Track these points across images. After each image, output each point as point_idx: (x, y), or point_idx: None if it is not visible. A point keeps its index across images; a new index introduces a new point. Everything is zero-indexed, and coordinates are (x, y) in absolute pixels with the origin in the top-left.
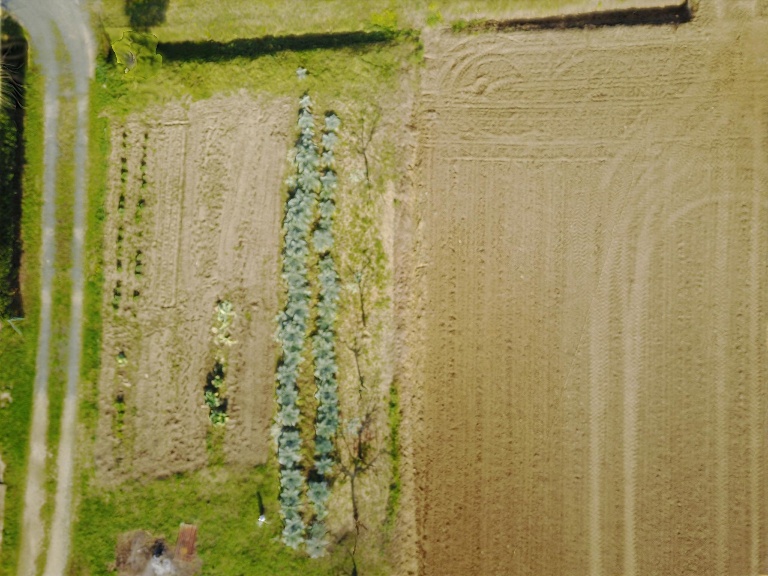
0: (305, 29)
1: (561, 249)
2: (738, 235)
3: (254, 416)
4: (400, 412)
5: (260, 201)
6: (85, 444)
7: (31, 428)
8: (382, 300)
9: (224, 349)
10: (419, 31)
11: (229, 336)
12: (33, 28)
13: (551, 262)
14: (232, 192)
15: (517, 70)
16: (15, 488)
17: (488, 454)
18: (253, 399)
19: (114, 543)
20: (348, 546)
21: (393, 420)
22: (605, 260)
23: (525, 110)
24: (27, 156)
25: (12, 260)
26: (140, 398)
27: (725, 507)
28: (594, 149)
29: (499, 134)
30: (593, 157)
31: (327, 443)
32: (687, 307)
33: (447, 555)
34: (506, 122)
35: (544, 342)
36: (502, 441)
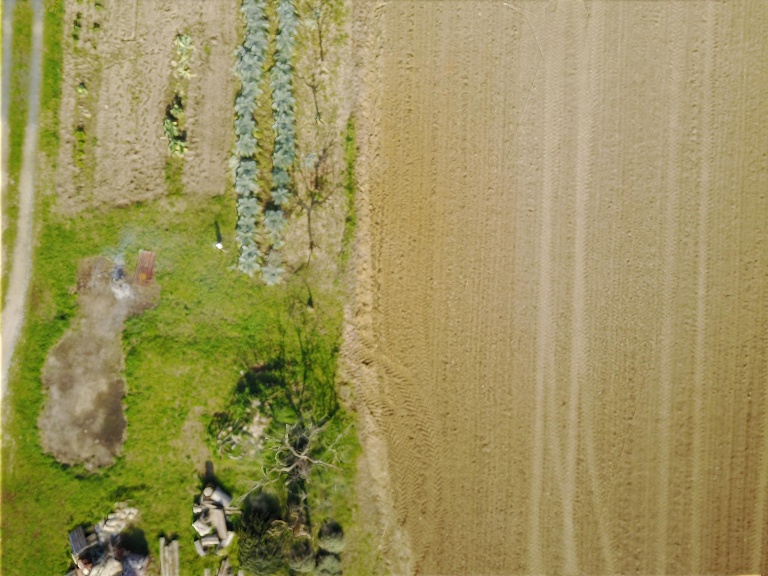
0: None
1: None
2: None
3: (212, 148)
4: (357, 148)
5: None
6: (46, 172)
7: None
8: (340, 37)
9: (183, 82)
10: None
11: (188, 69)
12: None
13: None
14: None
15: None
16: None
17: (443, 188)
18: (212, 132)
19: (75, 268)
20: (304, 276)
21: (350, 155)
22: None
23: None
24: None
25: None
26: (100, 129)
27: (675, 238)
28: None
29: None
30: None
31: (284, 174)
32: (642, 38)
33: (401, 286)
34: None
35: (500, 79)
36: (457, 174)
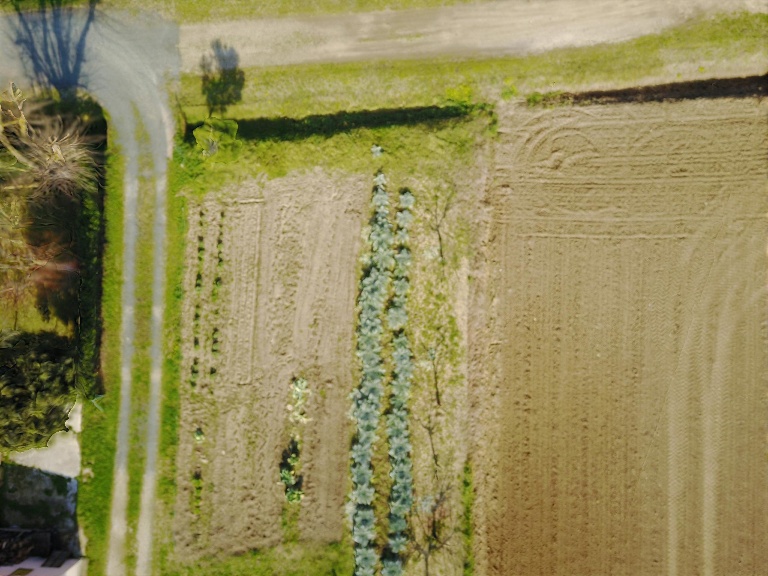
0: (378, 104)
1: (639, 328)
2: None
3: (329, 493)
4: (474, 491)
5: (334, 279)
6: (164, 519)
7: (112, 503)
8: (456, 378)
9: (299, 426)
10: (492, 105)
11: (304, 413)
12: (112, 108)
13: (628, 341)
14: (307, 270)
15: (593, 145)
16: (97, 562)
17: (564, 535)
18: (328, 476)
19: None
20: None
21: (468, 499)
22: (685, 340)
23: (601, 186)
24: (107, 235)
25: (95, 341)
26: (217, 474)
27: None
28: (673, 226)
29: (575, 210)
30: (672, 234)
31: (402, 522)
32: None
33: None
34: (582, 198)
35: (621, 422)
36: (579, 523)
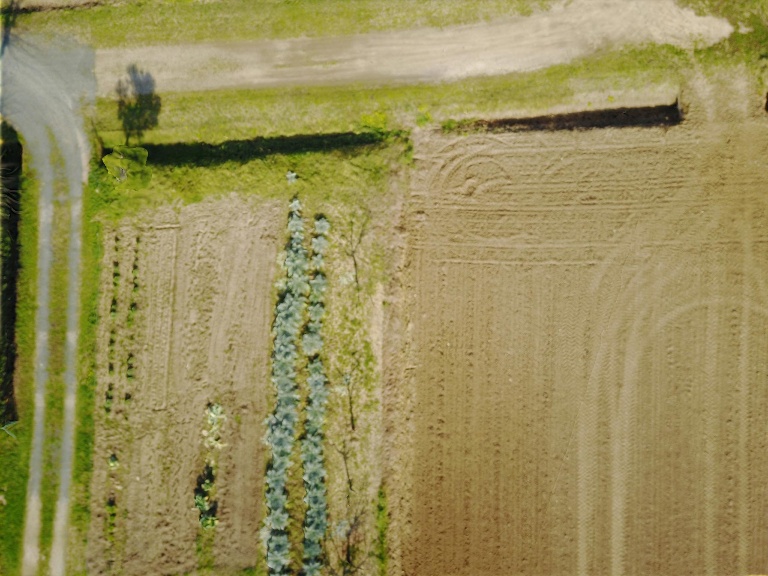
0: (295, 130)
1: (550, 353)
2: (728, 340)
3: (244, 519)
4: (389, 515)
5: (250, 304)
6: (77, 546)
7: (25, 530)
8: (371, 403)
9: (214, 452)
10: (408, 132)
11: (219, 439)
12: (27, 133)
13: (540, 365)
14: (222, 295)
15: (506, 172)
16: None
17: (476, 558)
18: (243, 502)
19: None
20: None
21: (381, 523)
22: (594, 365)
23: (514, 212)
24: (21, 260)
25: (5, 368)
26: (131, 500)
27: None
28: (583, 252)
29: (488, 237)
30: (582, 260)
31: (316, 547)
32: (676, 414)
33: None
34: (495, 225)
35: (532, 446)
36: (490, 546)
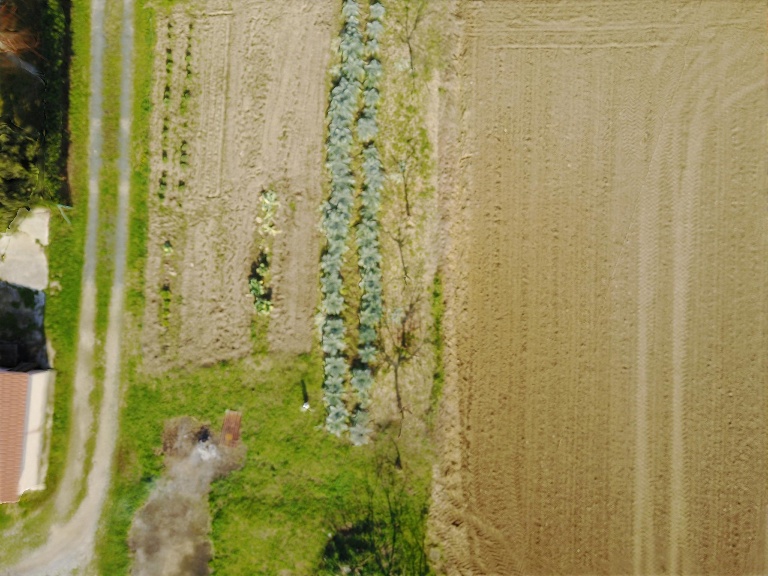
0: None
1: (609, 137)
2: None
3: (298, 305)
4: (444, 303)
5: (304, 91)
6: (132, 331)
7: (80, 315)
8: (426, 190)
9: (268, 239)
10: None
11: (273, 226)
12: None
13: (599, 151)
14: (276, 82)
15: None
16: (65, 373)
17: (533, 344)
18: (297, 288)
19: (161, 428)
20: (392, 435)
21: (437, 310)
22: (655, 147)
23: None
24: (74, 47)
25: (61, 146)
26: (186, 287)
27: None
28: (645, 34)
29: (546, 21)
30: (643, 42)
31: (371, 332)
32: (741, 193)
33: (491, 445)
34: (553, 8)
35: (591, 232)
36: (548, 331)
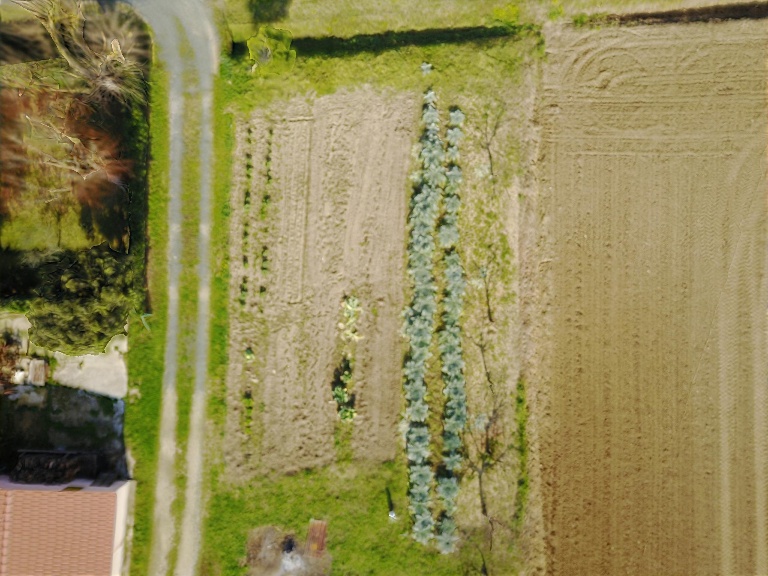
0: (426, 25)
1: (688, 243)
2: None
3: (381, 412)
4: (527, 407)
5: (385, 196)
6: (214, 440)
7: (160, 424)
8: (508, 295)
9: (351, 345)
10: (540, 26)
11: (356, 332)
12: (157, 25)
13: (678, 256)
14: (357, 188)
15: (641, 64)
16: (145, 484)
17: (617, 449)
18: (380, 395)
19: (244, 539)
20: (477, 542)
21: (520, 415)
22: (734, 254)
23: (650, 104)
24: (153, 153)
25: None
26: (268, 394)
27: None
28: (720, 143)
29: (624, 128)
30: (720, 151)
31: (456, 439)
32: None
33: (577, 551)
34: (631, 116)
35: (672, 337)
36: (631, 436)
